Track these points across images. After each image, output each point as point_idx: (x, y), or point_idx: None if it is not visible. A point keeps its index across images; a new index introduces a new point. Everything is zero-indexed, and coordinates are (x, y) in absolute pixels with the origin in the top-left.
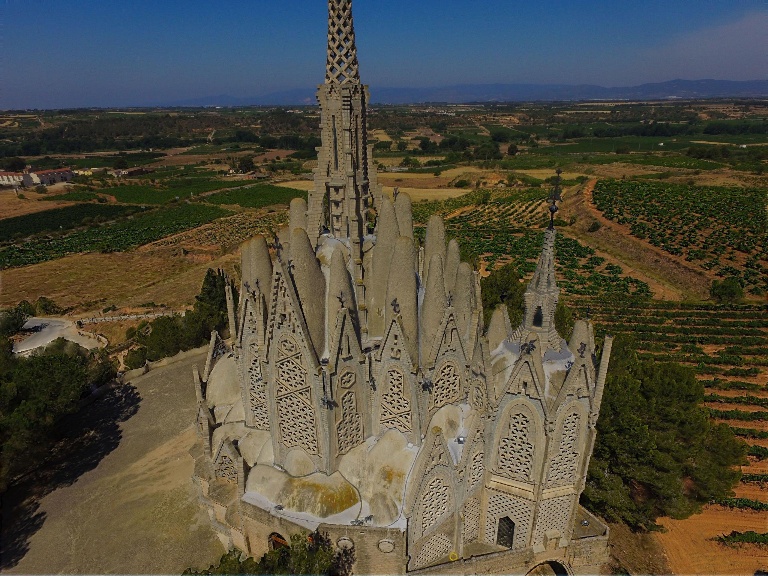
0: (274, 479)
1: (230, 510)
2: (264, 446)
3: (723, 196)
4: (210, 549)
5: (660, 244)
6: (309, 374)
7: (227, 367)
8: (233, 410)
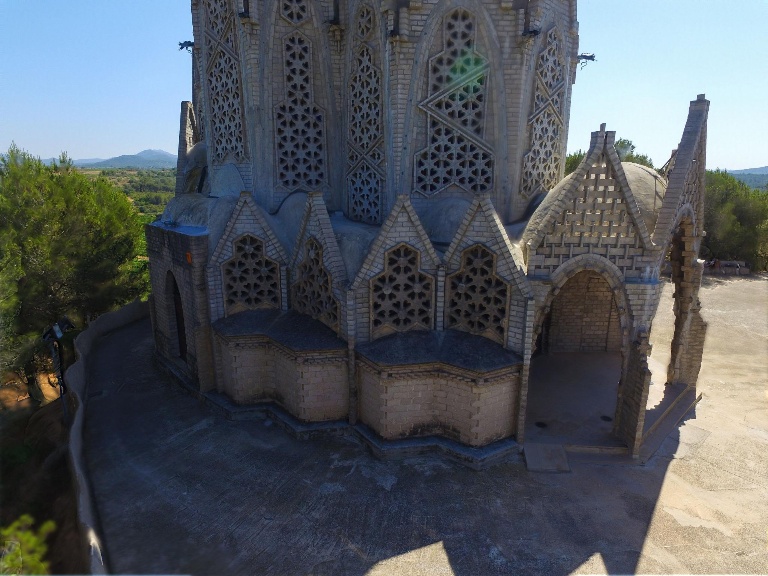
0: None
1: None
2: None
3: None
4: None
5: None
6: None
7: None
8: None
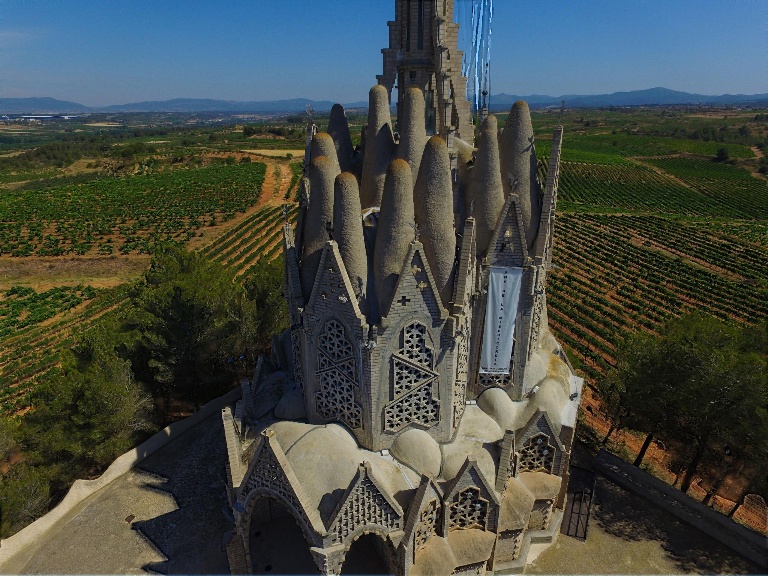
0: (553, 389)
1: (542, 492)
2: (504, 404)
3: (1, 204)
4: (552, 567)
5: (30, 253)
6: (547, 252)
7: (345, 443)
8: (429, 450)
